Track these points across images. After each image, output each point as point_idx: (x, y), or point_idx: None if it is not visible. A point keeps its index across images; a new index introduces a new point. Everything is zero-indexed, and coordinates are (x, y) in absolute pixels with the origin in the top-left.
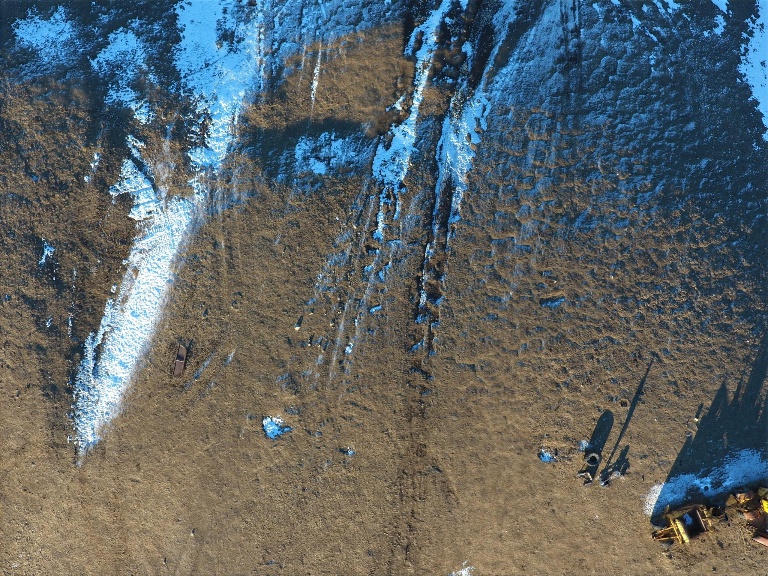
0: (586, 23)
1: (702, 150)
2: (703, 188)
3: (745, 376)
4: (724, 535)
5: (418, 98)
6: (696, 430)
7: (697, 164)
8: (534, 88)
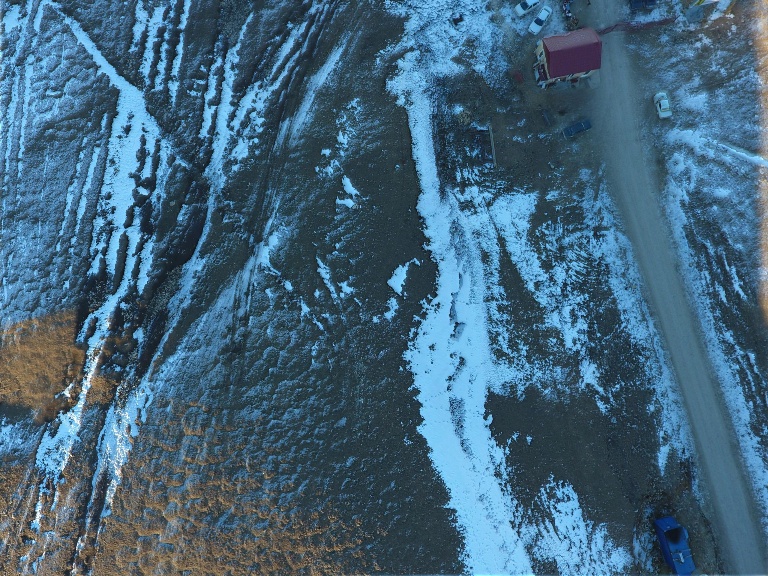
0: (256, 310)
1: (349, 448)
2: (344, 489)
3: None
4: None
5: (87, 385)
6: None
7: (342, 463)
8: (195, 380)
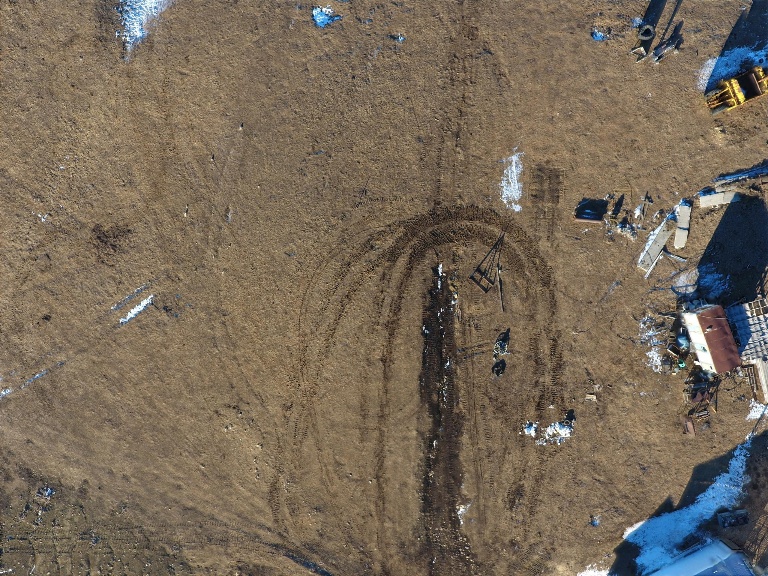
0: None
1: None
2: None
3: None
4: None
5: None
6: (751, 3)
7: None
8: None
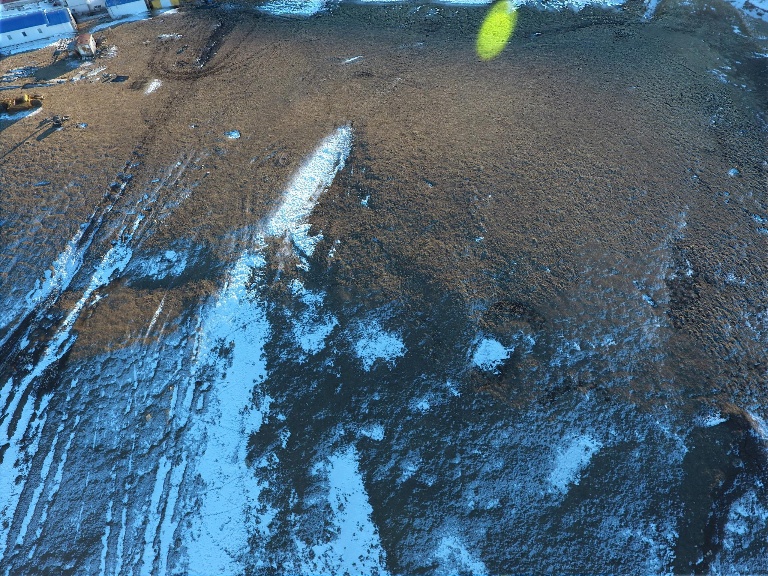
0: None
1: None
2: None
3: None
4: None
5: (80, 304)
6: None
7: None
8: None
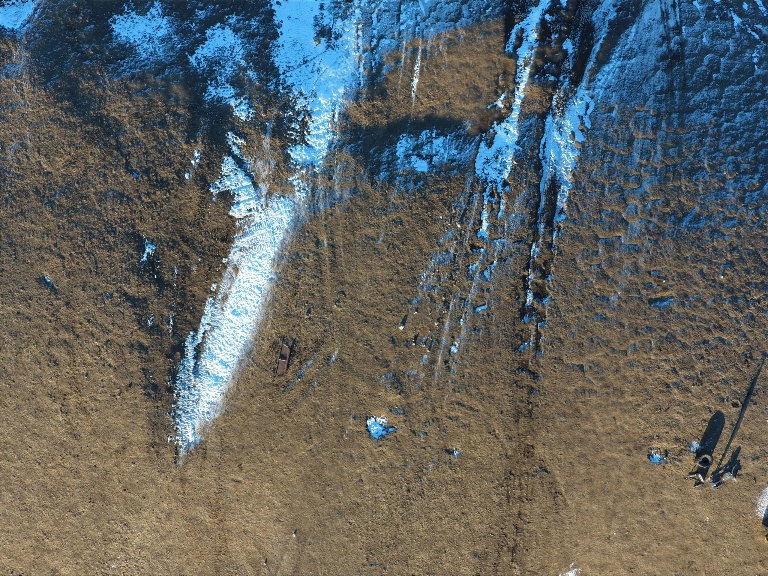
0: (687, 21)
1: None
2: None
3: None
4: None
5: (520, 96)
6: None
7: None
8: (638, 86)
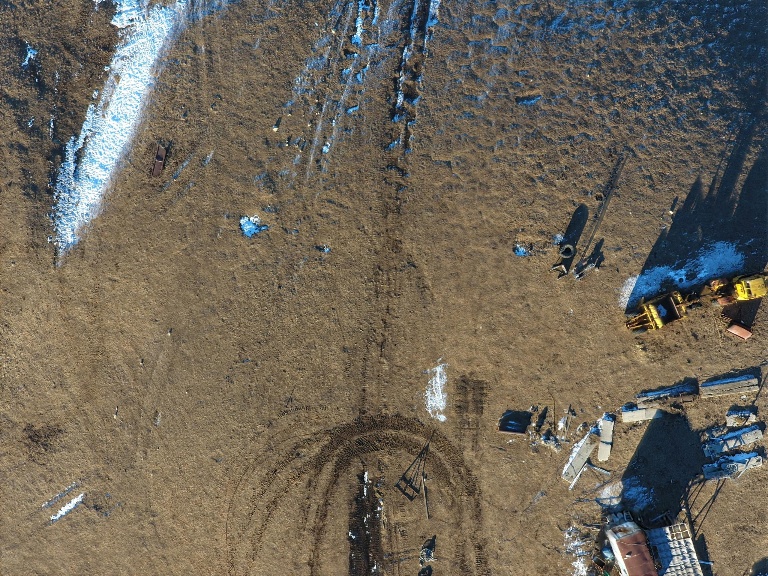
0: None
1: None
2: None
3: (720, 170)
4: (699, 327)
5: None
6: (671, 223)
7: None
8: None
